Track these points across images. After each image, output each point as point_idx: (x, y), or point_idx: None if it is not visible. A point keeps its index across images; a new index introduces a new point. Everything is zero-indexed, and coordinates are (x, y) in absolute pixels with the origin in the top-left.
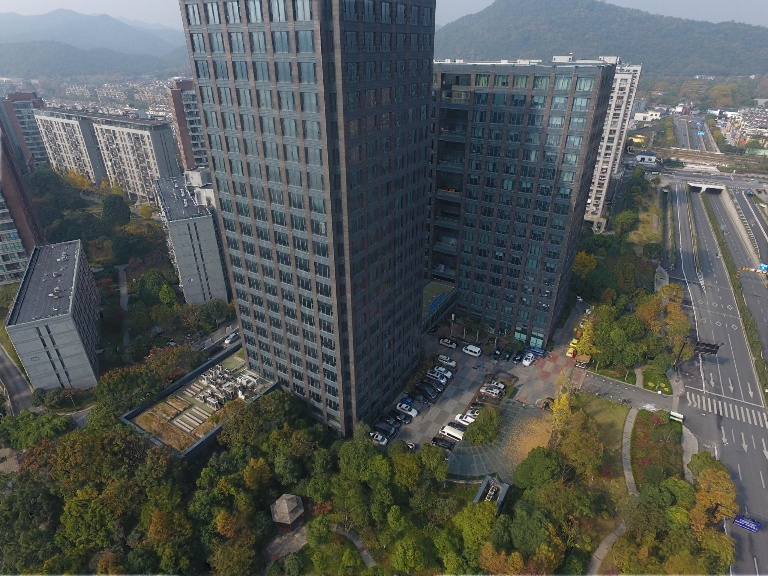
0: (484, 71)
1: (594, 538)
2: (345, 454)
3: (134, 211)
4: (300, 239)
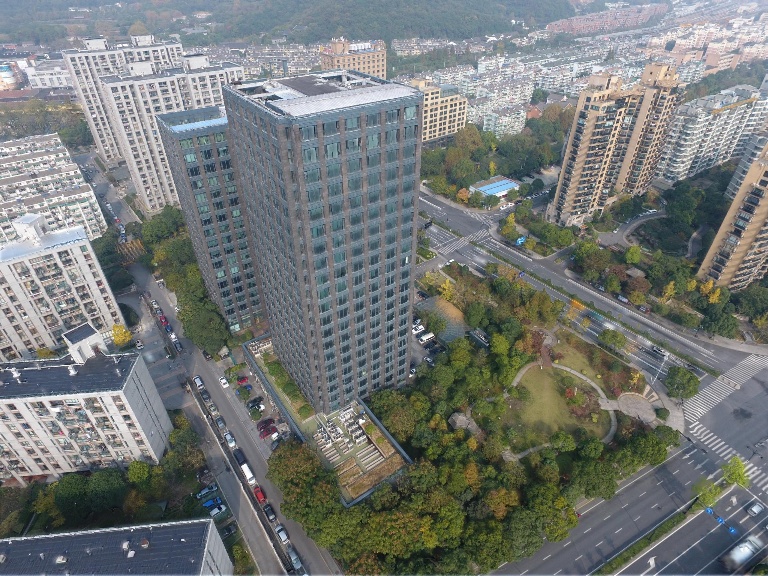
0: None
1: None
2: (442, 378)
3: None
4: (390, 278)
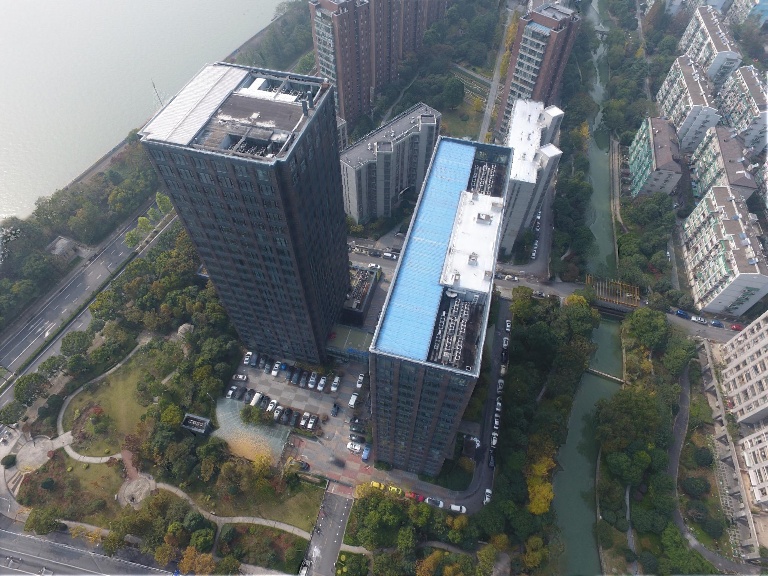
0: None
1: (187, 489)
2: None
3: (493, 93)
4: None
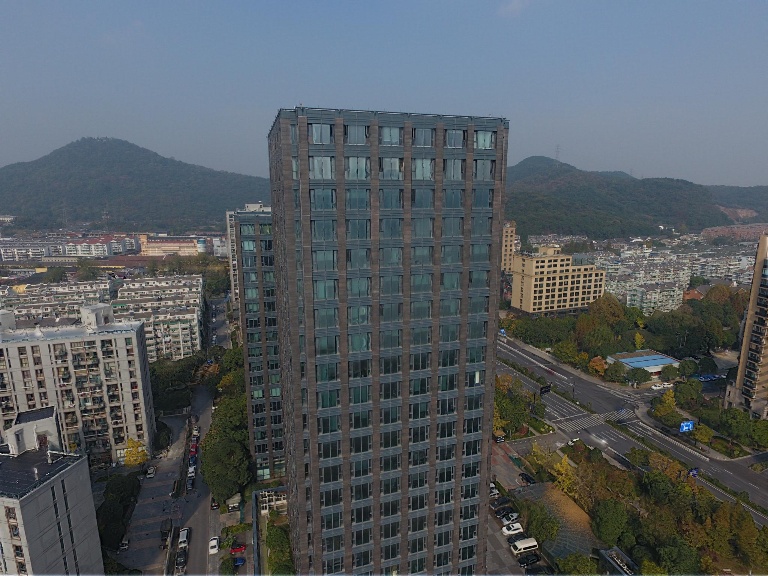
0: None
1: None
2: None
3: None
4: (447, 401)
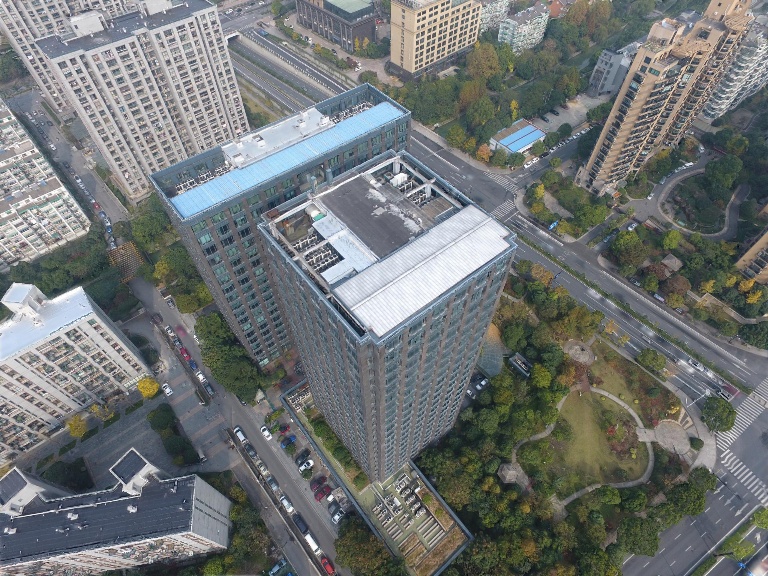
0: (334, 155)
1: None
2: (489, 428)
3: None
4: None
